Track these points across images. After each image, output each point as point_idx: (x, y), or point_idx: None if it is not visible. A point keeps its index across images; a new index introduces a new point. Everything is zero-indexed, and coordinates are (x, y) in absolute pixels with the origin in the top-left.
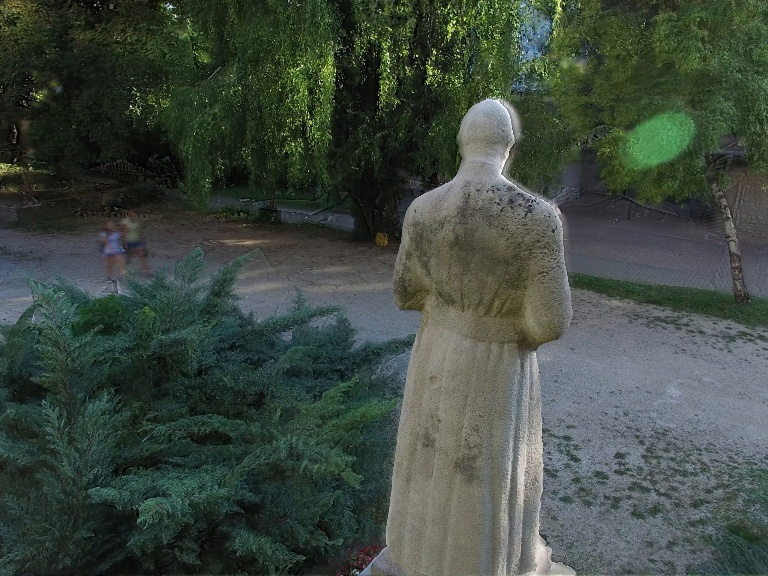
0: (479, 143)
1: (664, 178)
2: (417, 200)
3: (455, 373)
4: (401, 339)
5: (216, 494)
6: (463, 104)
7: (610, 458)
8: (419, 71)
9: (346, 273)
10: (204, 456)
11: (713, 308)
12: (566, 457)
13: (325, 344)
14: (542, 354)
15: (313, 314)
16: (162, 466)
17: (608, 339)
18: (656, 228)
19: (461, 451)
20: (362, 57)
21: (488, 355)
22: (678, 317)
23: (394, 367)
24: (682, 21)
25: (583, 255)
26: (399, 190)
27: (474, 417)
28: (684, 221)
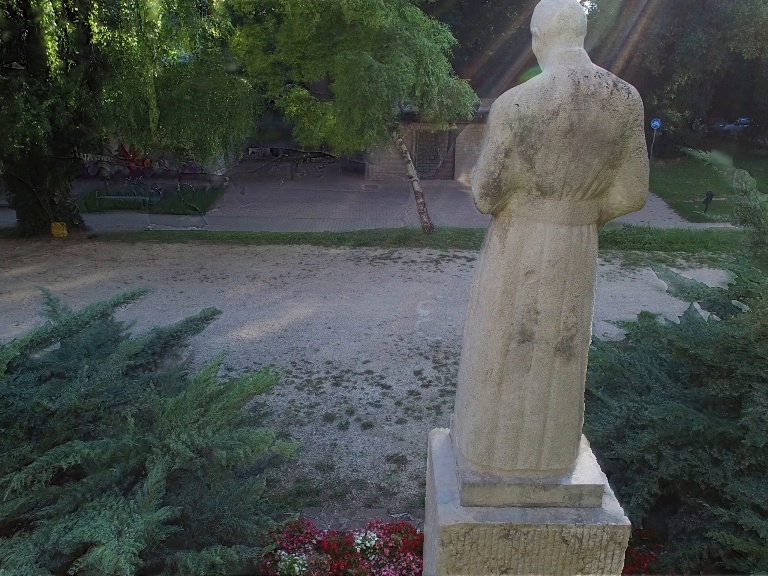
0: (572, 33)
1: (365, 128)
2: (512, 95)
3: (555, 262)
4: (196, 316)
5: (153, 519)
6: (148, 64)
7: (412, 377)
8: (82, 27)
9: (35, 273)
10: (79, 494)
11: (412, 241)
12: (378, 388)
13: (103, 343)
14: (302, 308)
15: (115, 303)
16: (36, 523)
17: (348, 282)
18: (320, 185)
19: (560, 335)
20: (16, 6)
21: (581, 238)
22: (390, 253)
23: (189, 349)
24: None
25: (269, 217)
26: (70, 170)
27: (571, 299)
28: (339, 176)
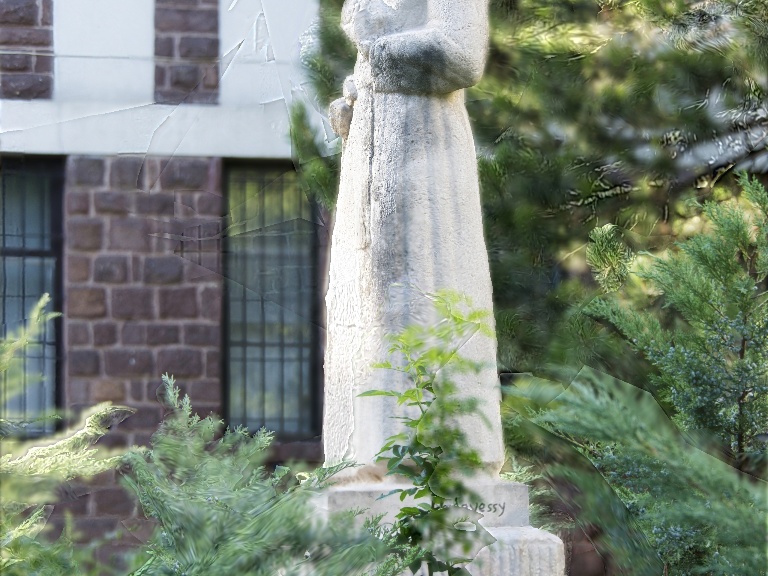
0: None
1: None
2: None
3: None
4: None
5: None
6: None
7: None
8: None
9: None
10: None
11: None
12: None
13: None
14: None
15: None
16: None
17: None
18: None
19: None
20: None
21: None
22: None
23: None
24: None
25: None
26: None
27: None
28: None
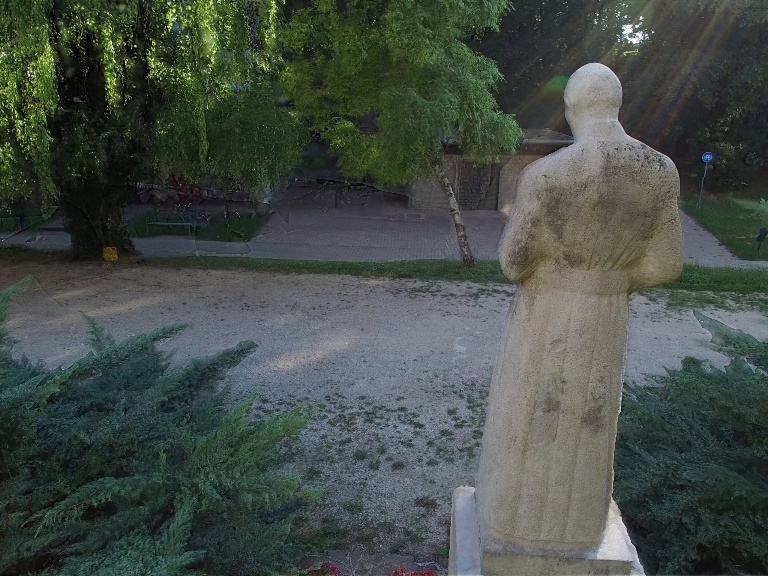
0: (602, 105)
1: (407, 162)
2: (540, 165)
3: (582, 331)
4: (233, 349)
5: (177, 564)
6: (200, 98)
7: (445, 416)
8: (140, 63)
9: (85, 297)
10: (108, 531)
11: (451, 273)
12: (411, 426)
13: (143, 373)
14: (339, 340)
15: (155, 337)
16: (65, 560)
17: (386, 315)
18: (363, 213)
19: (588, 405)
20: (80, 45)
21: (610, 307)
22: (429, 285)
23: (226, 381)
24: (408, 20)
25: (312, 245)
26: (123, 197)
27: (600, 369)
28: (383, 204)
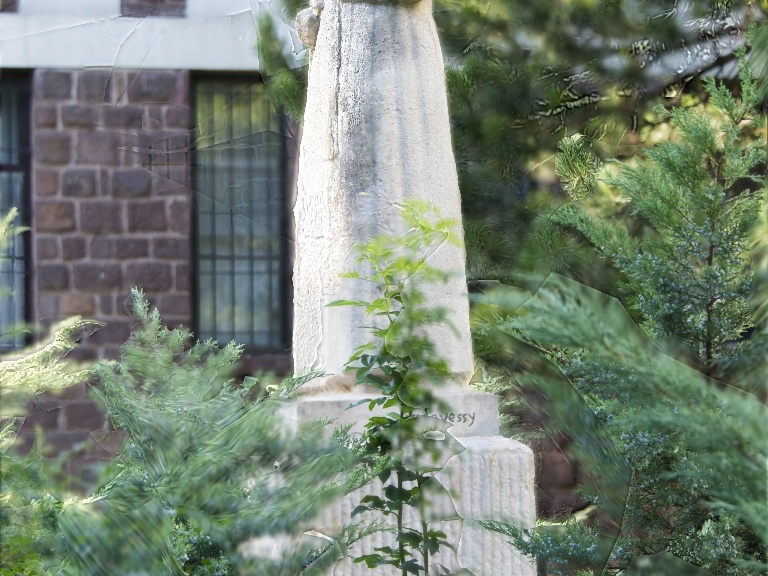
0: None
1: None
2: None
3: None
4: None
5: None
6: None
7: None
8: None
9: None
10: None
11: None
12: None
13: None
14: None
15: None
16: None
17: None
18: None
19: None
20: None
21: None
22: None
23: None
24: None
25: None
26: None
27: None
28: None
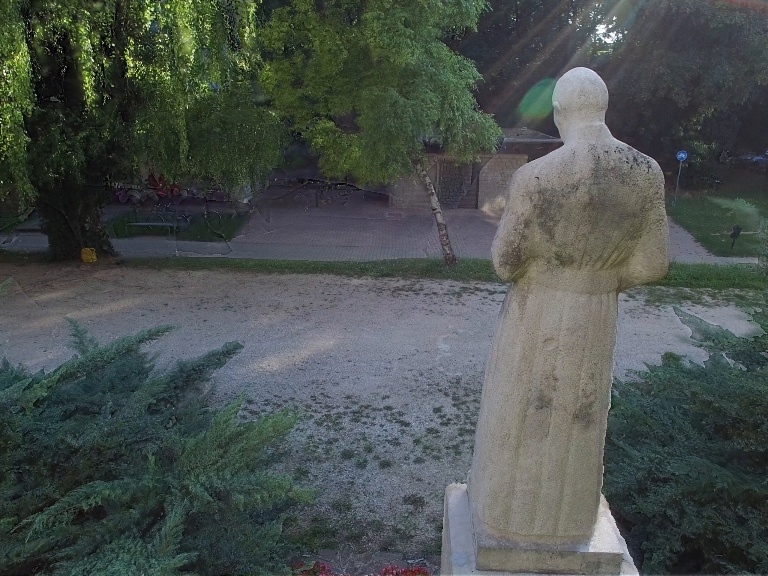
0: (592, 108)
1: (389, 162)
2: (532, 168)
3: (574, 329)
4: (219, 350)
5: (170, 566)
6: (180, 98)
7: (431, 414)
8: (118, 62)
9: (64, 299)
10: (98, 535)
11: (434, 272)
12: (397, 425)
13: (128, 376)
14: (323, 339)
15: (140, 340)
16: (55, 566)
17: (369, 314)
18: (344, 212)
19: (579, 402)
20: (57, 44)
21: (601, 306)
22: (412, 284)
23: (211, 383)
24: (389, 20)
25: (293, 244)
26: (101, 197)
27: (591, 367)
28: (363, 203)
